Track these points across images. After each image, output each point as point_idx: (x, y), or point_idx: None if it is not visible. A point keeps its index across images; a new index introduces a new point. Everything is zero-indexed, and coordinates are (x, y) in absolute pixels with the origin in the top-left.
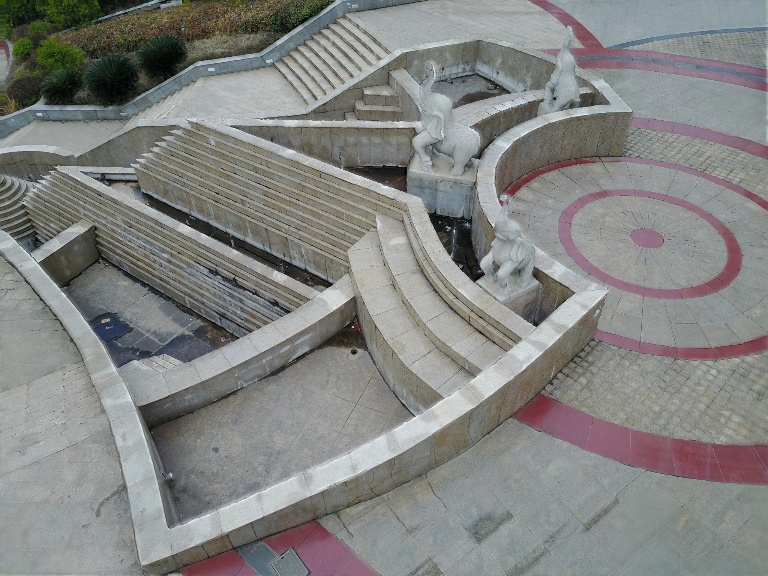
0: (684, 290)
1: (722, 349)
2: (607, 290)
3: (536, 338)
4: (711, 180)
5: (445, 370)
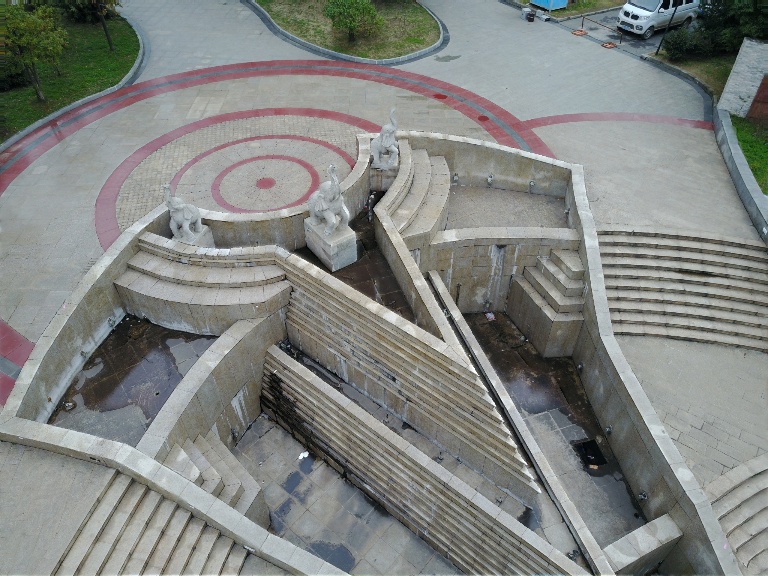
0: (294, 161)
1: (318, 143)
2: (357, 134)
3: (406, 134)
4: (175, 191)
5: (437, 168)
